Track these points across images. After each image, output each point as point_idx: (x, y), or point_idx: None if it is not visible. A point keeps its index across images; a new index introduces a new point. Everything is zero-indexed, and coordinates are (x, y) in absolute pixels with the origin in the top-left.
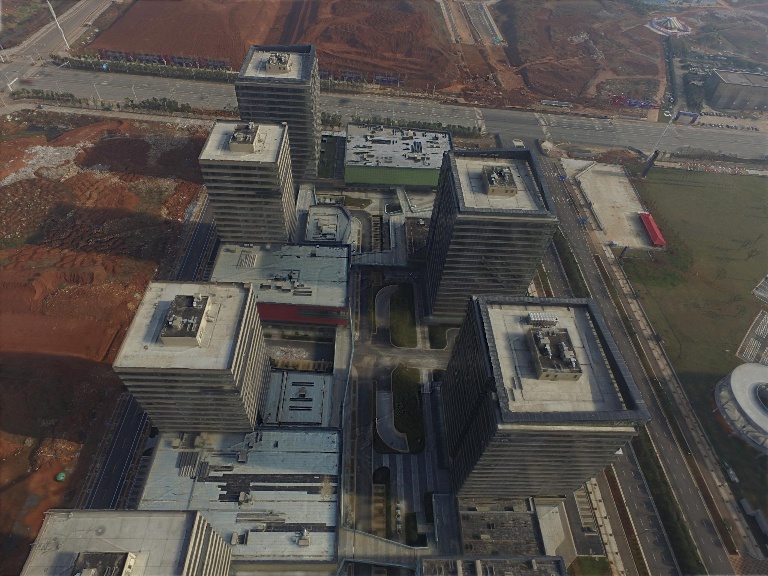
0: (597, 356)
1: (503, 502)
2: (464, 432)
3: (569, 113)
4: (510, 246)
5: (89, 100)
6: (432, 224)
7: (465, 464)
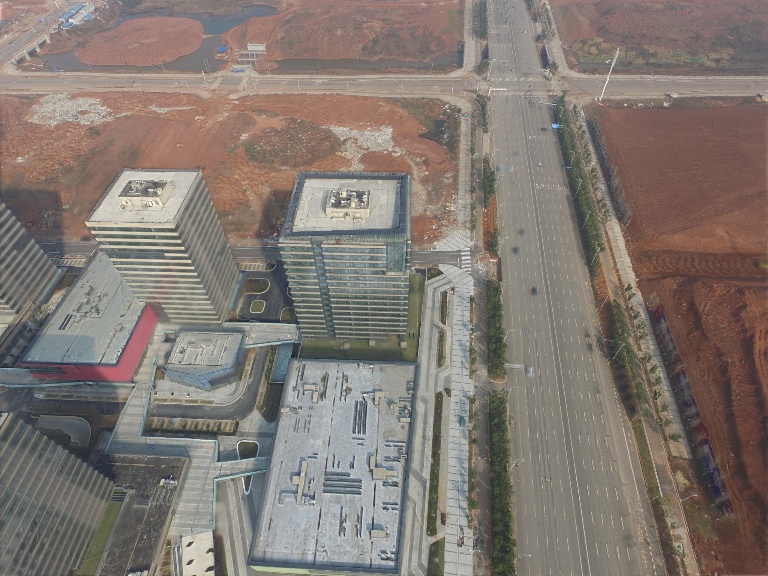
0: None
1: None
2: None
3: None
4: None
5: None
6: None
7: None
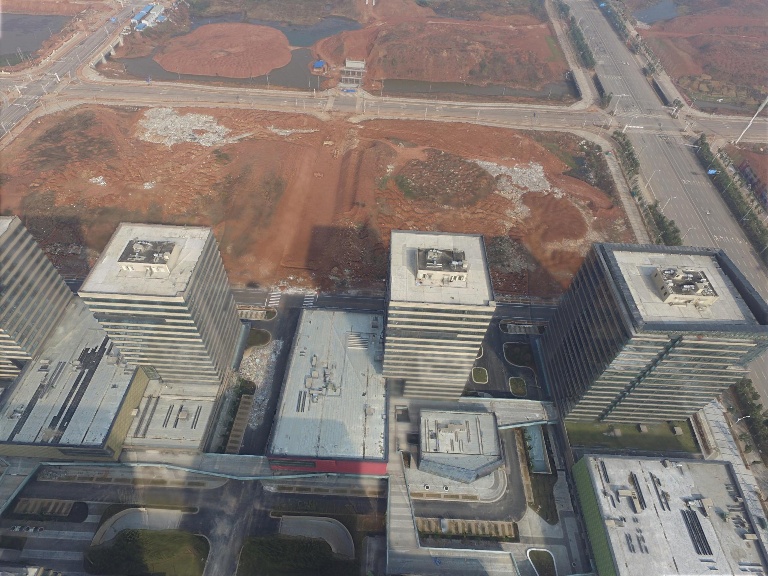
0: None
1: None
2: None
3: None
4: None
5: None
6: None
7: None
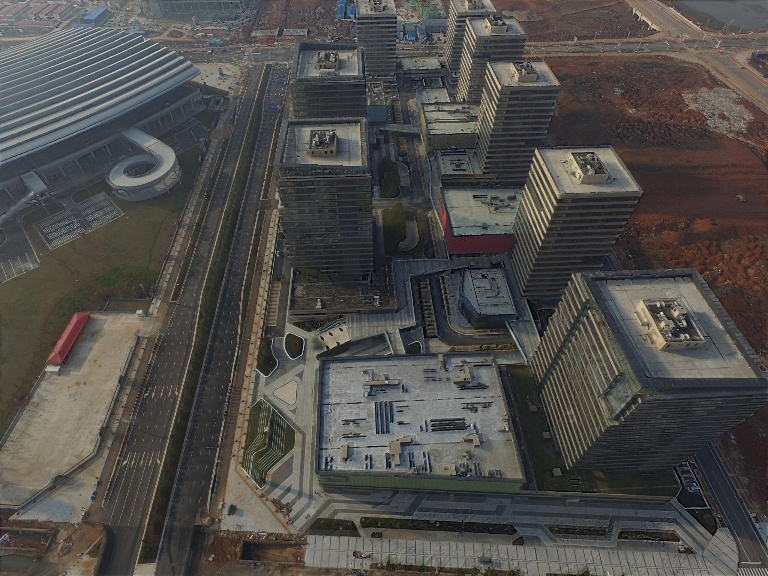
0: None
1: None
2: None
3: None
4: None
5: None
6: None
7: None
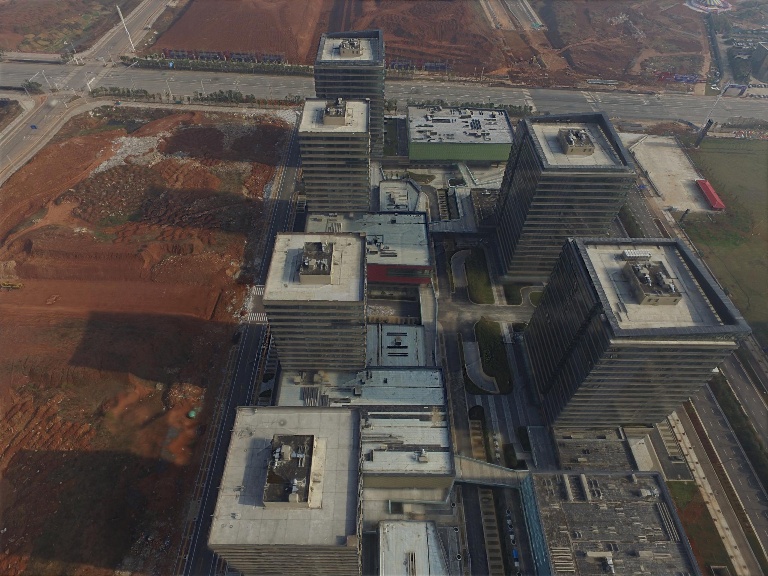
0: (691, 285)
1: (595, 432)
2: (560, 365)
3: (616, 90)
4: (588, 202)
5: (162, 95)
6: (503, 190)
7: (564, 391)
